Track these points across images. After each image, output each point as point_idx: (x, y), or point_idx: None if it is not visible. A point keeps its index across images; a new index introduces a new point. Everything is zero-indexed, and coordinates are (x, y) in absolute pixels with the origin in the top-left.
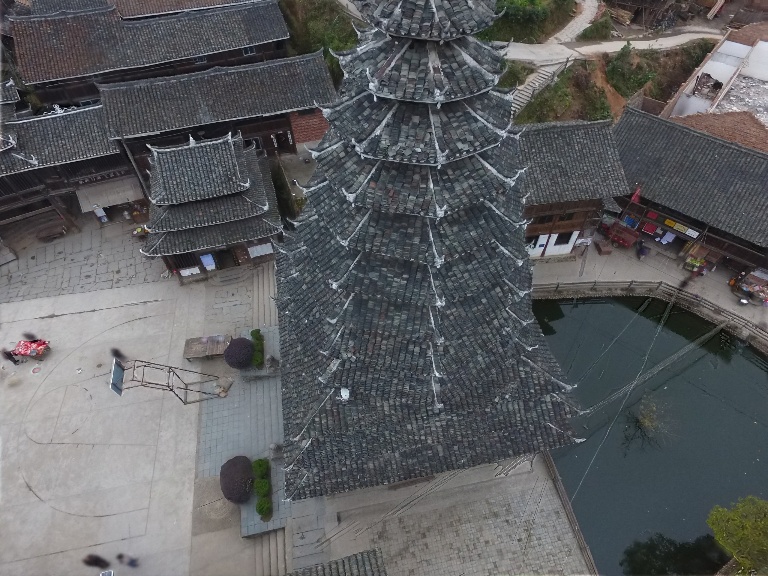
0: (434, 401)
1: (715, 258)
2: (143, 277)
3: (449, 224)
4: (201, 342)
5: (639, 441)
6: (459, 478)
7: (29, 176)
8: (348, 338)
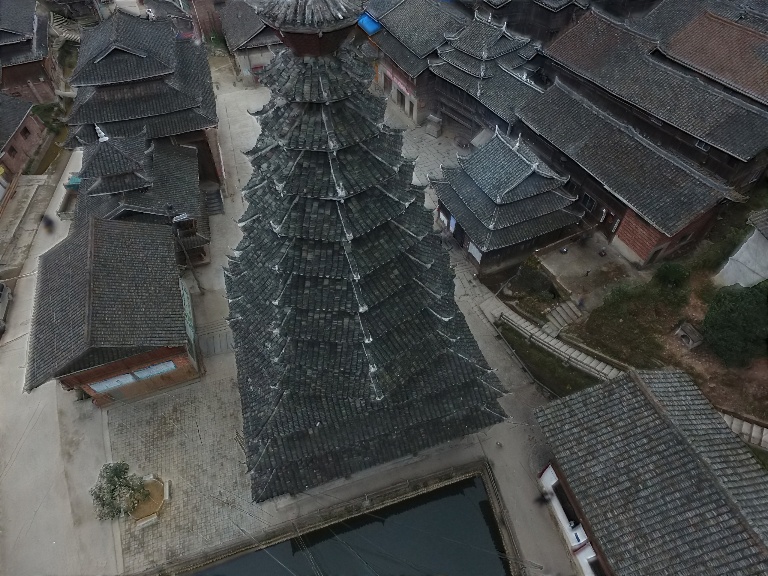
0: None
1: None
2: None
3: None
4: None
5: None
6: None
7: None
8: None
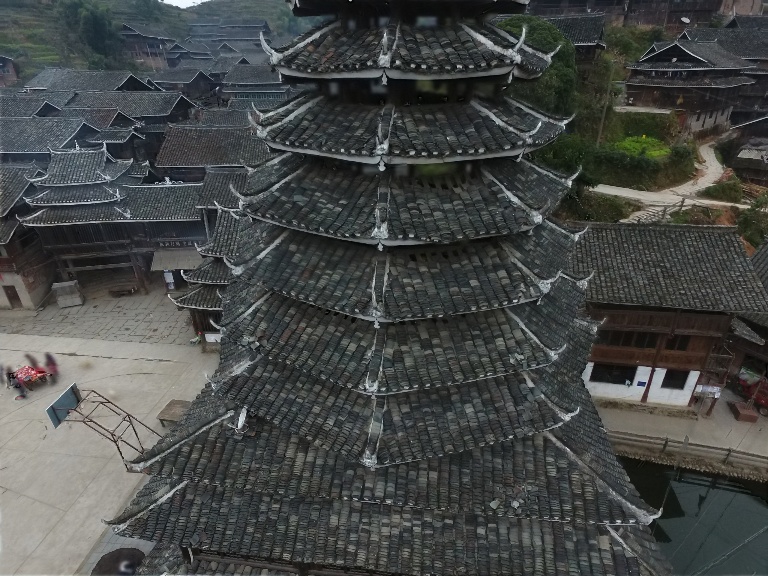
0: (363, 451)
1: None
2: (173, 339)
3: (415, 122)
4: (184, 406)
5: None
6: None
7: (121, 230)
8: (262, 318)
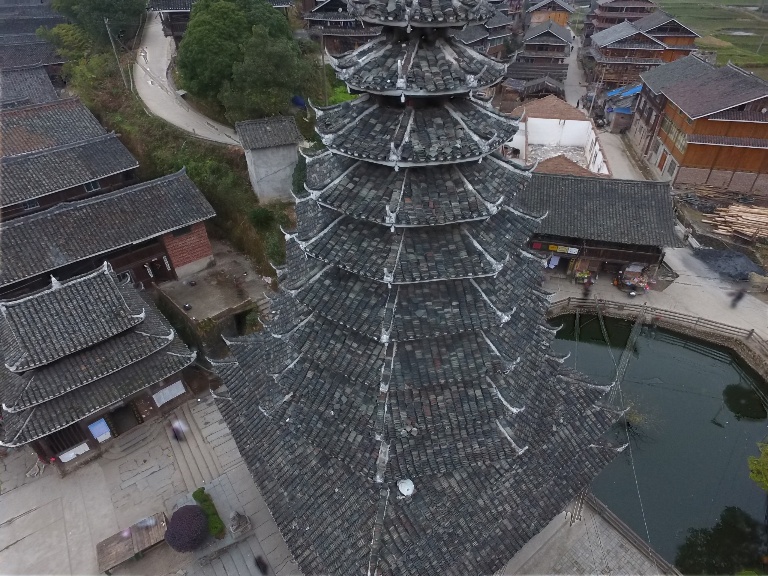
0: (513, 449)
1: (595, 267)
2: None
3: (485, 232)
4: (121, 539)
5: (632, 443)
6: (514, 558)
7: None
8: (397, 409)
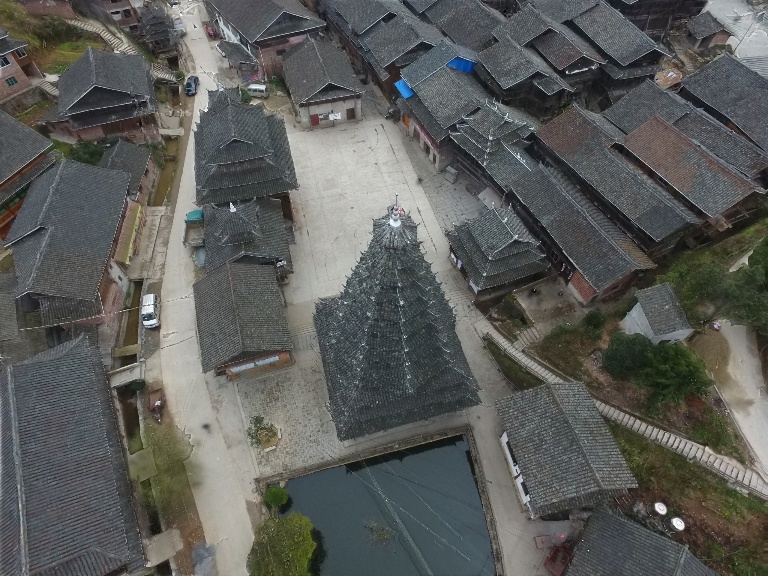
0: None
1: None
2: None
3: None
4: None
5: None
6: None
7: None
8: None
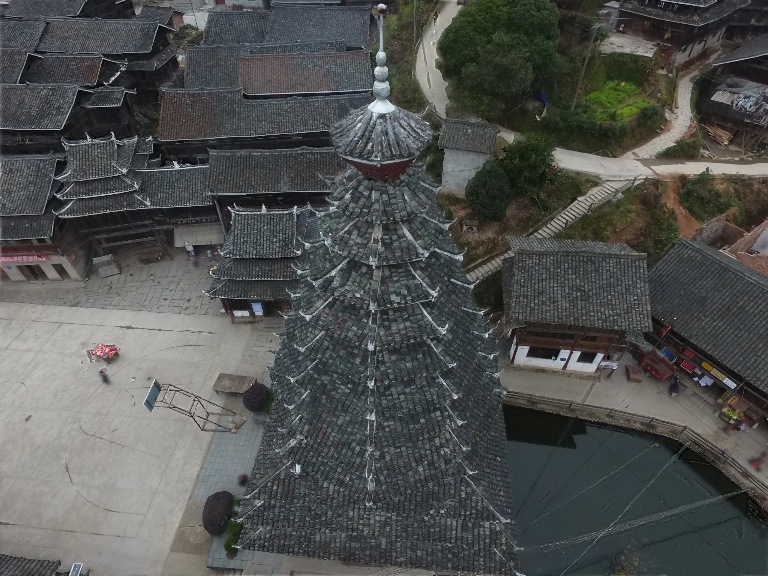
0: (366, 498)
1: (756, 415)
2: (206, 309)
3: (389, 352)
4: (230, 379)
5: None
6: (411, 574)
7: (143, 212)
8: (305, 422)
